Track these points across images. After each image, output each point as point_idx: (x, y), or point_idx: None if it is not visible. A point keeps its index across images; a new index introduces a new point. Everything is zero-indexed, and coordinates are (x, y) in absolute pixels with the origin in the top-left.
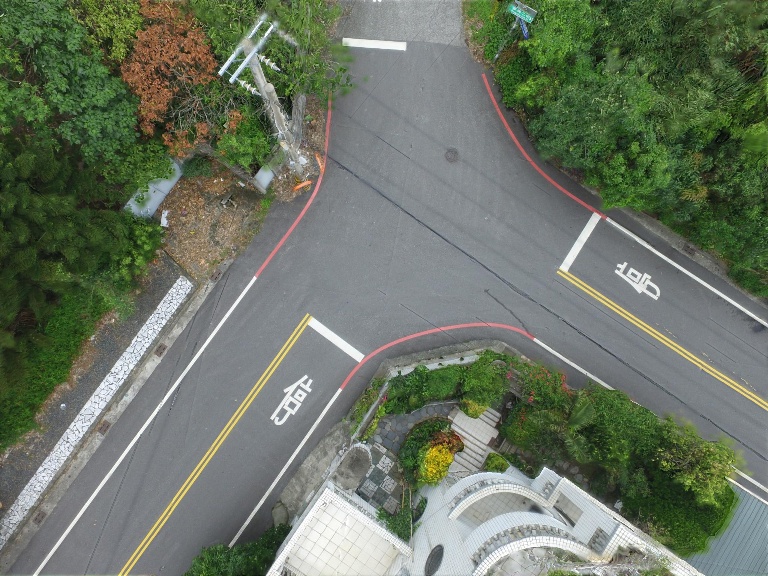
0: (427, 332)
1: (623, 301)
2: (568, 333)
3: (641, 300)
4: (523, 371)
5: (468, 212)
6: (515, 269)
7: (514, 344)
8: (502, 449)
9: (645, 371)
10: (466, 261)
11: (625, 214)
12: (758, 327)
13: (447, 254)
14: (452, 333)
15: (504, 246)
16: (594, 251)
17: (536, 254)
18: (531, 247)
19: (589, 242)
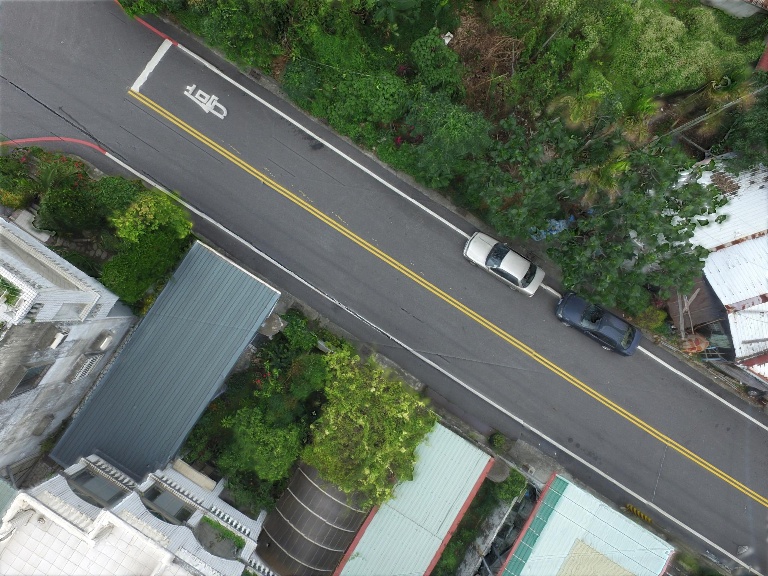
0: (0, 143)
1: (191, 120)
2: (138, 148)
3: (208, 119)
4: (42, 158)
5: (45, 36)
6: (88, 89)
7: (88, 158)
8: (55, 245)
9: (210, 184)
10: (42, 81)
11: (196, 41)
12: (318, 145)
13: (23, 74)
14: (26, 146)
15: (78, 67)
16: (165, 74)
17: (108, 75)
18: (104, 69)
19: (161, 66)
